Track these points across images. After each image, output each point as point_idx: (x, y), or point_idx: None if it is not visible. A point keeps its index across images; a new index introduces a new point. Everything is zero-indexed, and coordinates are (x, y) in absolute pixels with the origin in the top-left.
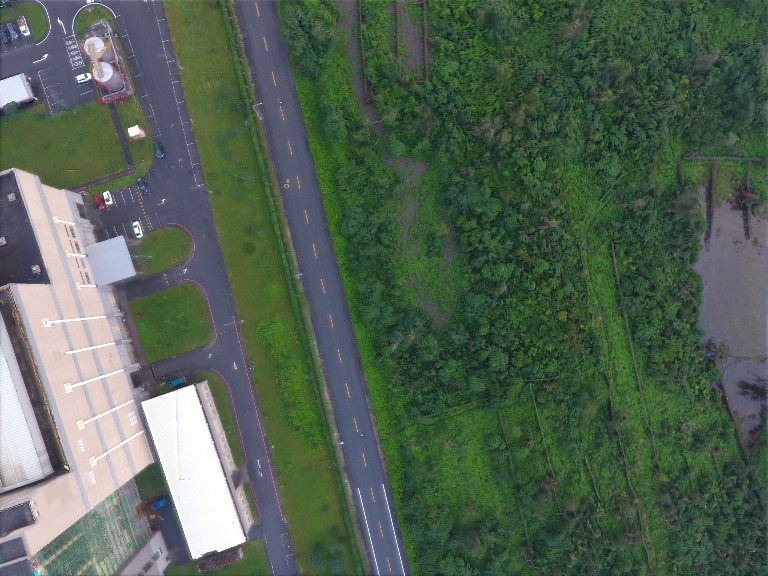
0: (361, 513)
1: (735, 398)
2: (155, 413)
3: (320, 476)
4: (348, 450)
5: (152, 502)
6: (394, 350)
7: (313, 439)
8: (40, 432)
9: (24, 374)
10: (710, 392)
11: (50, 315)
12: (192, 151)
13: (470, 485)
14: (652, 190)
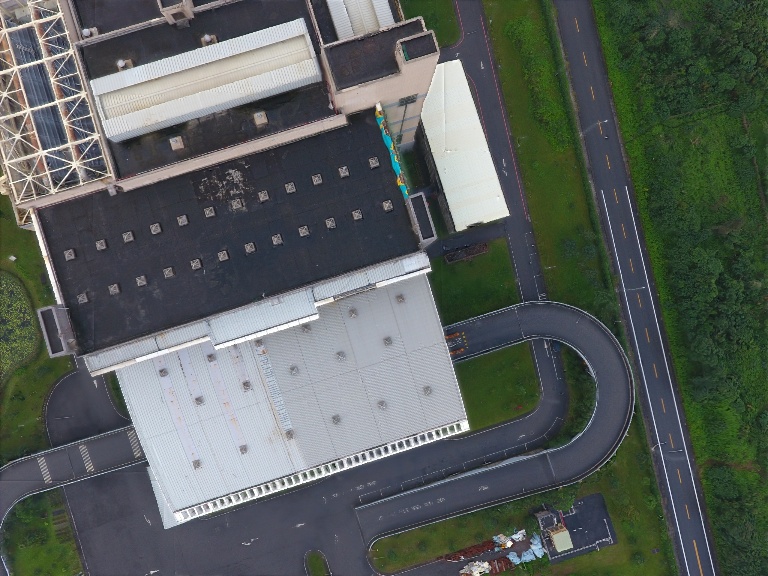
0: (604, 214)
1: None
2: None
3: (566, 175)
4: (592, 152)
5: None
6: (643, 50)
7: (562, 135)
8: None
9: None
10: None
11: None
12: None
13: (713, 187)
14: None
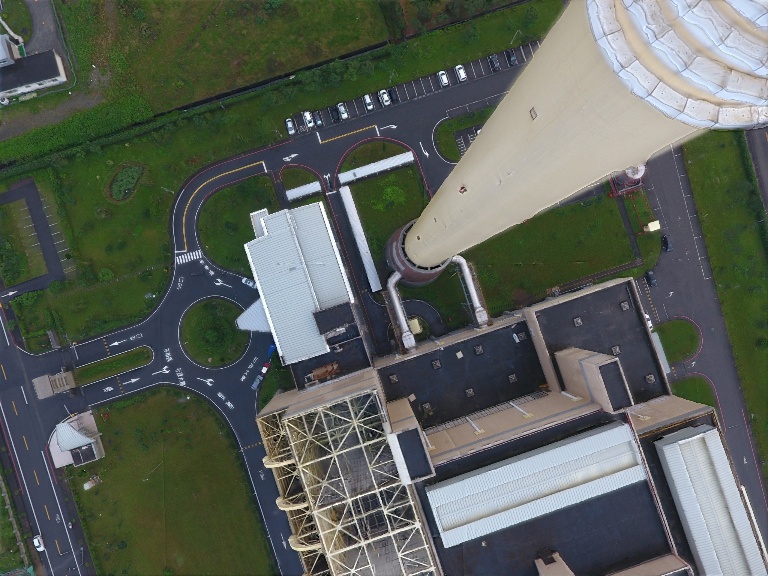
0: None
1: None
2: None
3: None
4: None
5: None
6: None
7: None
8: None
9: None
10: None
11: None
12: (699, 244)
13: None
14: None
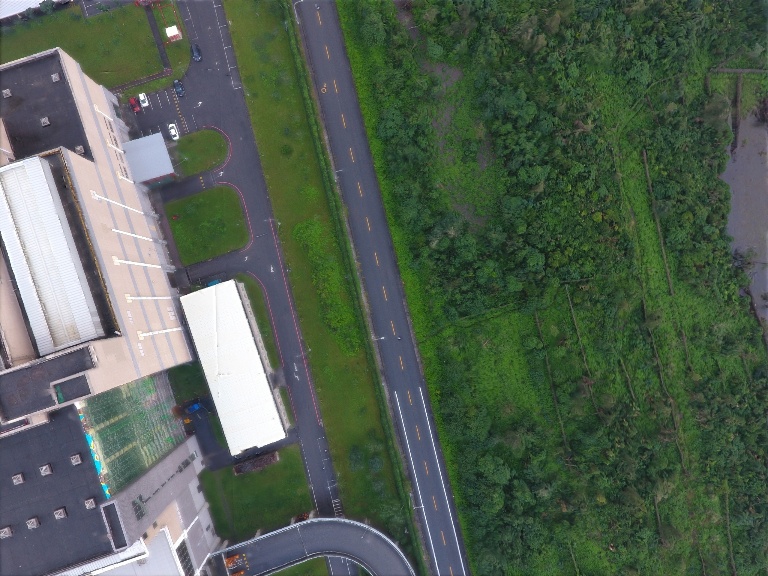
0: (398, 416)
1: (762, 306)
2: (194, 308)
3: (357, 379)
4: (385, 353)
5: (187, 406)
6: (432, 251)
7: (351, 341)
8: (91, 295)
9: (75, 237)
10: (738, 298)
11: (97, 190)
12: (229, 54)
13: (507, 387)
14: (682, 98)
